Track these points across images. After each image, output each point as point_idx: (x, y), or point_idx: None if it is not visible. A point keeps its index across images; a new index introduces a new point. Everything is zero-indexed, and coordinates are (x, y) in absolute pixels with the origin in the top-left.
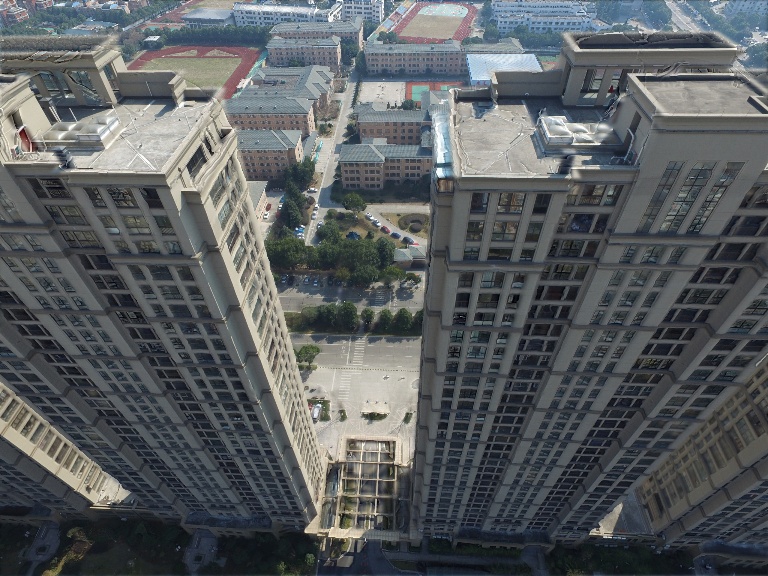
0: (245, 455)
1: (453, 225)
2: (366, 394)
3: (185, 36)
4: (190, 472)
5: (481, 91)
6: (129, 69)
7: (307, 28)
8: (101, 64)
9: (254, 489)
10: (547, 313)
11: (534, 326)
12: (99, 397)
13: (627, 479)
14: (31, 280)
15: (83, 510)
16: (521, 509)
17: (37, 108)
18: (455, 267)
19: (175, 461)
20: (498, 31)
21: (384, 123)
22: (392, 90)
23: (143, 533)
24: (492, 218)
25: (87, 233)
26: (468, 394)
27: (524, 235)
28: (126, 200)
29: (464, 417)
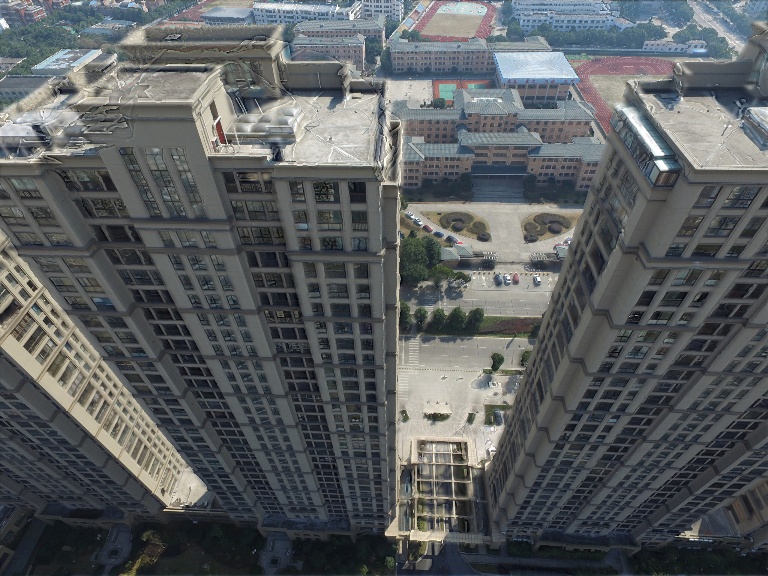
0: (349, 457)
1: (663, 220)
2: (426, 394)
3: (205, 35)
4: (282, 474)
5: (664, 82)
6: (293, 60)
7: (330, 26)
8: (272, 54)
9: (345, 491)
10: (722, 312)
11: (703, 325)
12: (214, 398)
13: (741, 481)
14: (190, 278)
15: (157, 513)
16: (614, 511)
17: (227, 99)
18: (654, 264)
19: (271, 463)
20: (521, 29)
21: (419, 121)
22: (419, 88)
23: (220, 536)
24: (715, 213)
25: (265, 229)
26: (610, 395)
27: (741, 230)
28: (328, 194)
29: (595, 418)
